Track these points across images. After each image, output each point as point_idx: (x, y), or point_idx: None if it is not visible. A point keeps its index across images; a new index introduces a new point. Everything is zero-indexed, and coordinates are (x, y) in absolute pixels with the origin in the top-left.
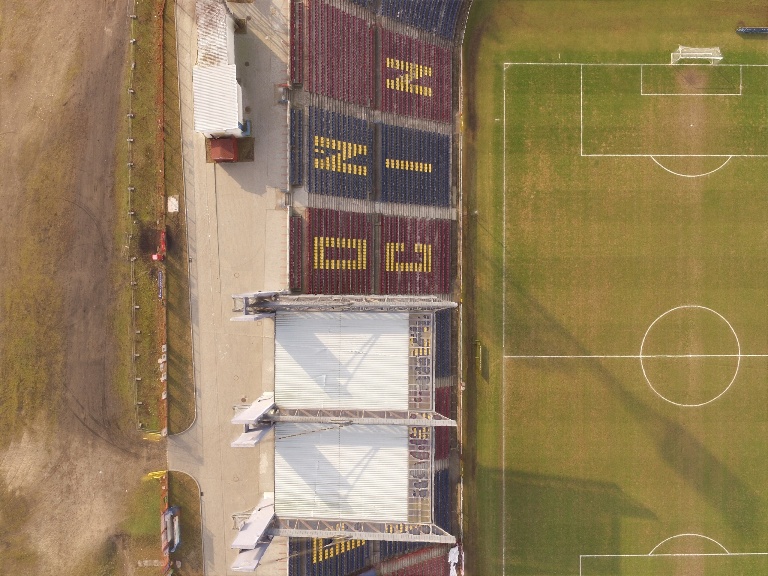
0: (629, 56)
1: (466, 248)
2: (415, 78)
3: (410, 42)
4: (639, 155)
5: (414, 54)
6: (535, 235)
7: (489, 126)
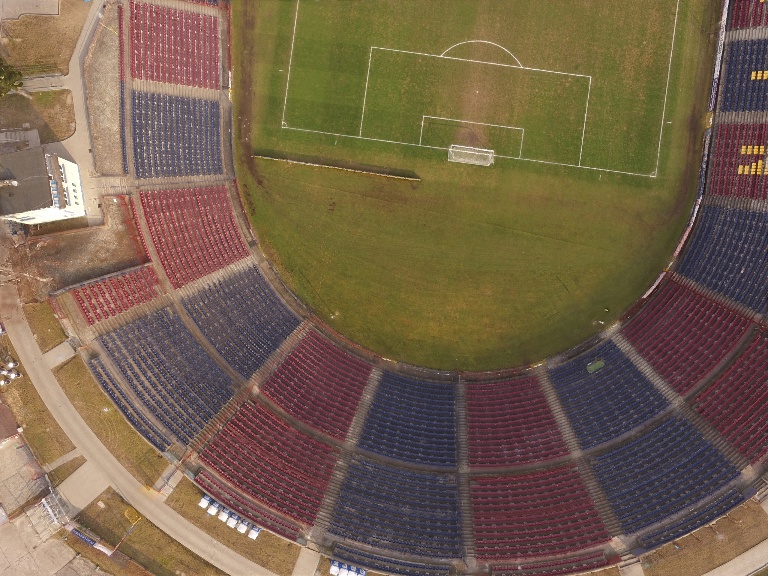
0: (532, 168)
1: (716, 1)
2: (762, 161)
3: (764, 195)
4: (534, 70)
5: (759, 185)
6: (647, 4)
7: (678, 118)
